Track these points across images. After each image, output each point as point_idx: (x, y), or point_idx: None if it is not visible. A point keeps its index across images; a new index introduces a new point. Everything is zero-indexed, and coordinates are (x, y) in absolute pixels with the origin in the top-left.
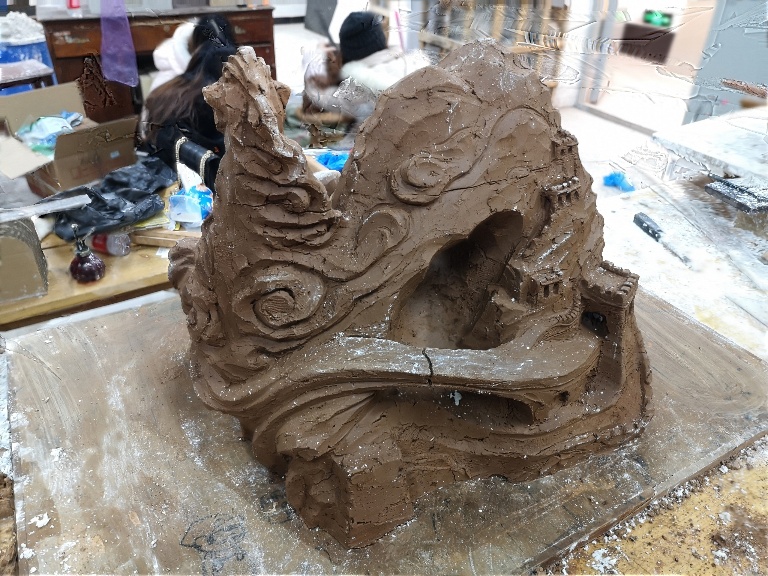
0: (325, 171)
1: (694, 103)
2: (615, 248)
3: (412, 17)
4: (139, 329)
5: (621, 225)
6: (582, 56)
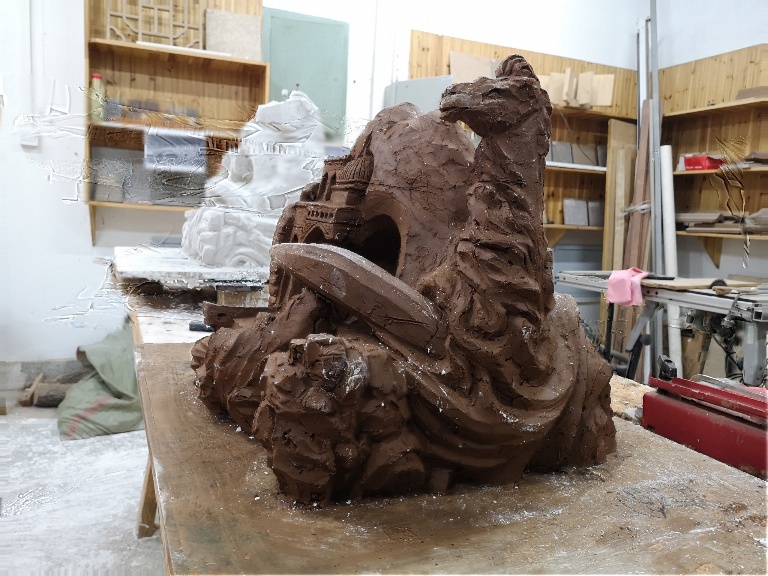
0: None
1: (275, 199)
2: None
3: (60, 121)
4: (267, 574)
5: (192, 334)
6: (262, 156)
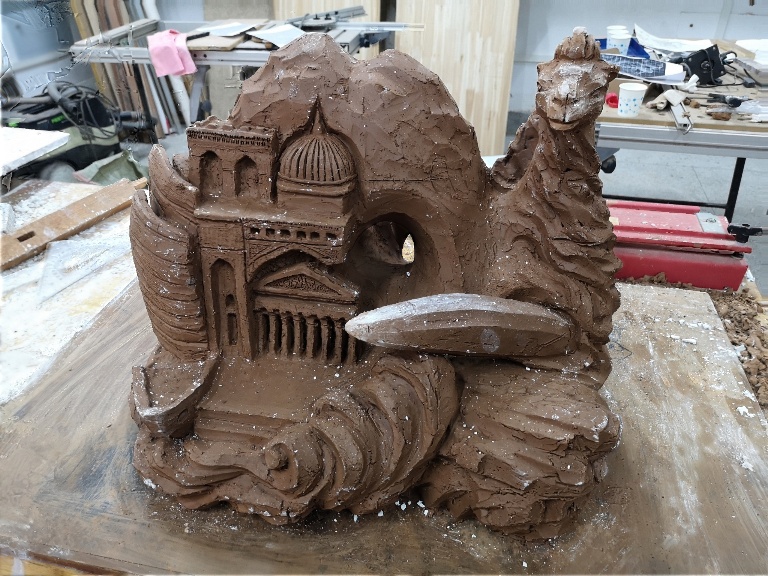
0: (374, 316)
1: None
2: None
3: None
4: None
5: None
6: None
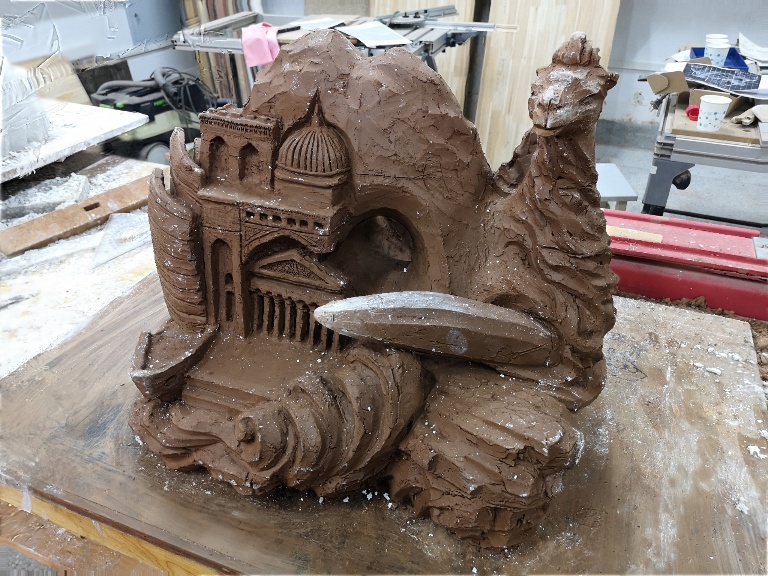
0: (341, 306)
1: None
2: (2, 345)
3: None
4: None
5: None
6: None
